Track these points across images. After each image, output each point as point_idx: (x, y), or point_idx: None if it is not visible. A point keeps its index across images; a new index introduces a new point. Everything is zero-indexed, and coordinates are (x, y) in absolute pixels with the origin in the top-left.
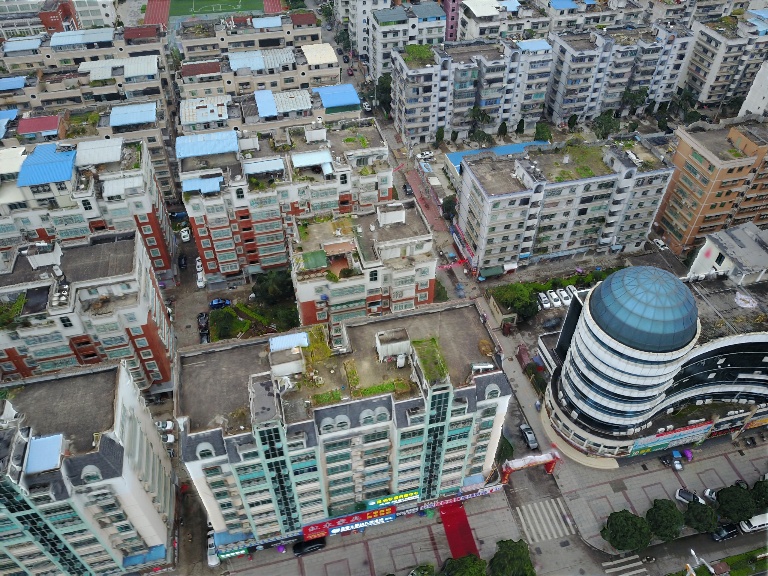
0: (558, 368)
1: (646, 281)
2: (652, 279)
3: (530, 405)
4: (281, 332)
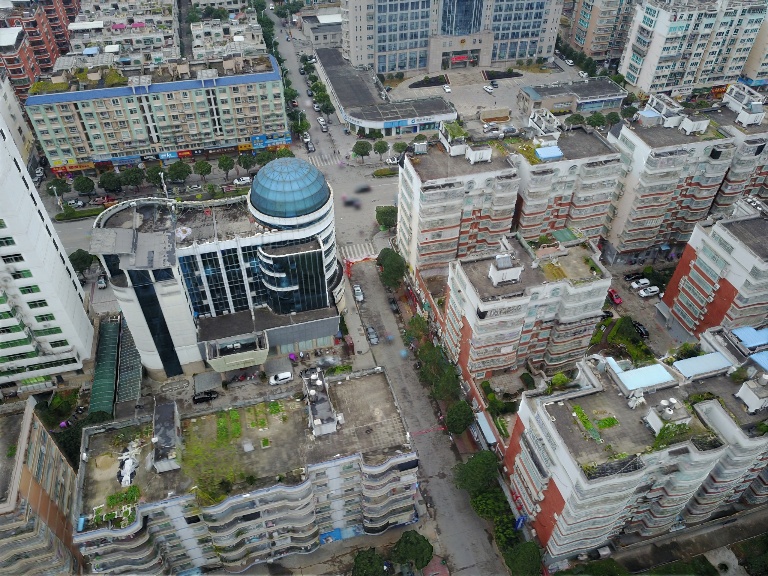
0: (331, 291)
1: (295, 163)
2: (290, 163)
3: (351, 314)
4: (558, 161)
